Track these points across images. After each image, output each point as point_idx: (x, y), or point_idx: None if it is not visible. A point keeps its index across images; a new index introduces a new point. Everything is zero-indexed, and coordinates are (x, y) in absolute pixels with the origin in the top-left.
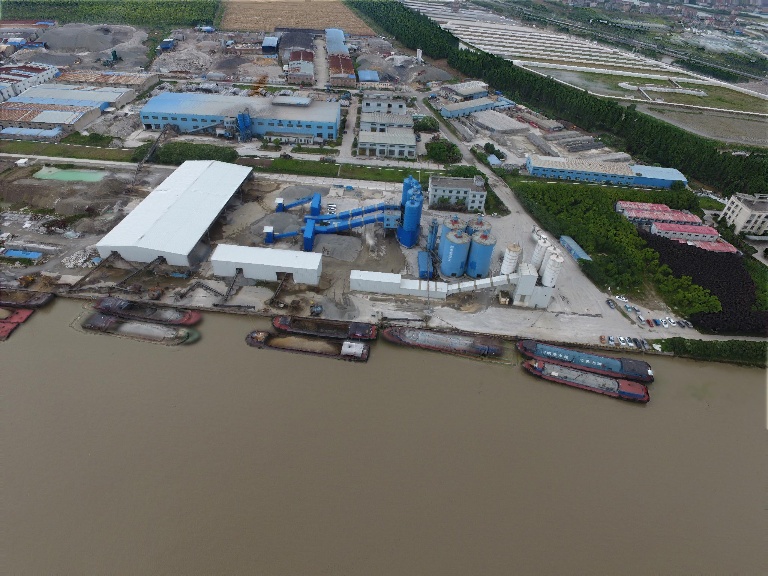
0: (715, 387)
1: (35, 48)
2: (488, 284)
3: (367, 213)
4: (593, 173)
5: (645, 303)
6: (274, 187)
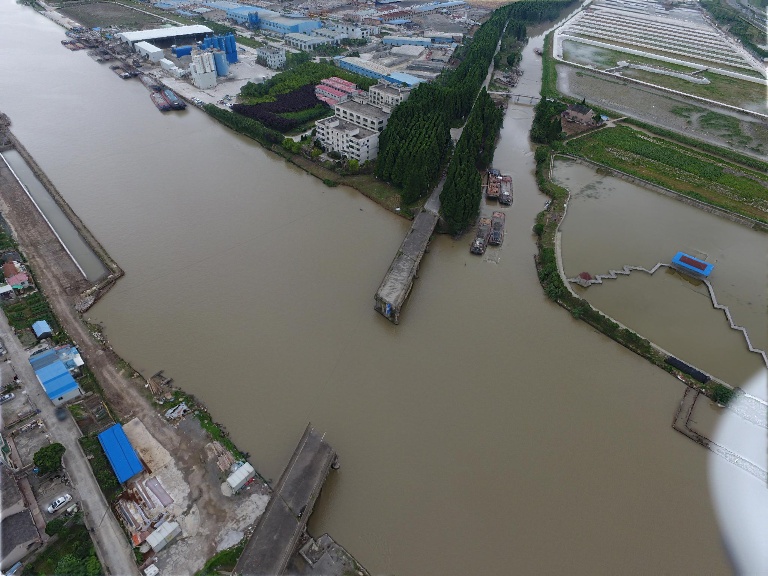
0: None
1: None
2: (187, 70)
3: None
4: (365, 69)
5: None
6: None
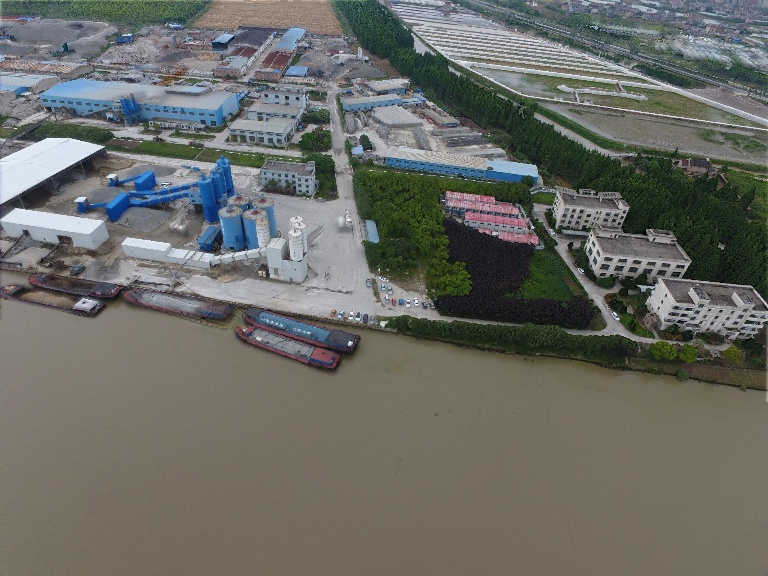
0: (414, 362)
1: (0, 40)
2: (243, 256)
3: (183, 190)
4: (444, 165)
5: (405, 284)
6: (125, 165)
